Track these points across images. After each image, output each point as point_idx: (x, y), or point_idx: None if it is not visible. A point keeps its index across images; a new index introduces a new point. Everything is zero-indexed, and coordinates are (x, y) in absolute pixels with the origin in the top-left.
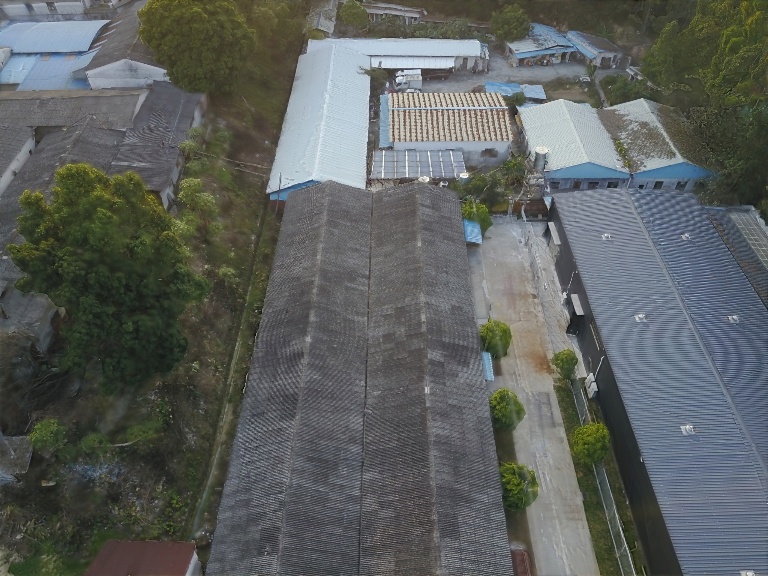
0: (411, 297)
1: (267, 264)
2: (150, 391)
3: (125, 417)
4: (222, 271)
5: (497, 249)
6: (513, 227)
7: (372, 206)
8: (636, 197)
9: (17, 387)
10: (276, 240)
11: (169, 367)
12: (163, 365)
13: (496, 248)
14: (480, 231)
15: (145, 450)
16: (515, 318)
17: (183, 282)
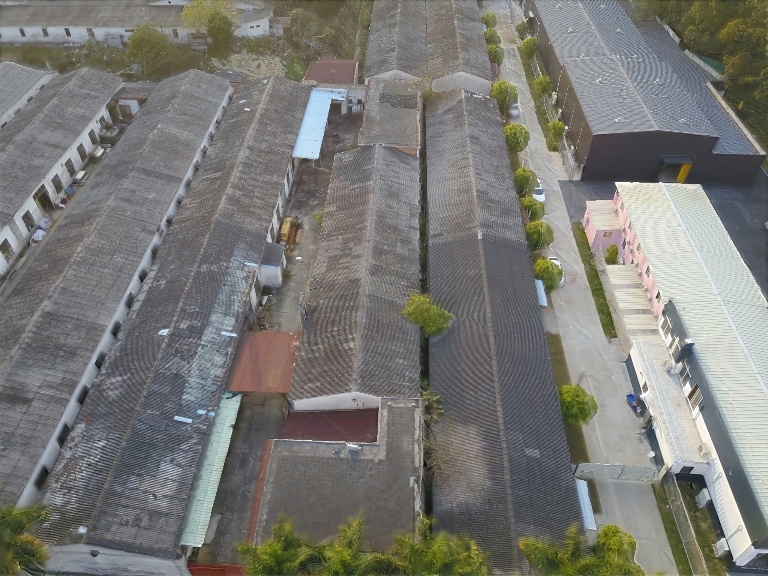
0: (448, 2)
1: (368, 7)
2: (326, 26)
3: (318, 32)
4: None
5: (493, 9)
6: (503, 2)
7: None
8: None
9: (279, 3)
10: (371, 1)
11: (337, 11)
12: (336, 8)
13: (492, 8)
14: None
15: (328, 42)
16: (500, 29)
17: None
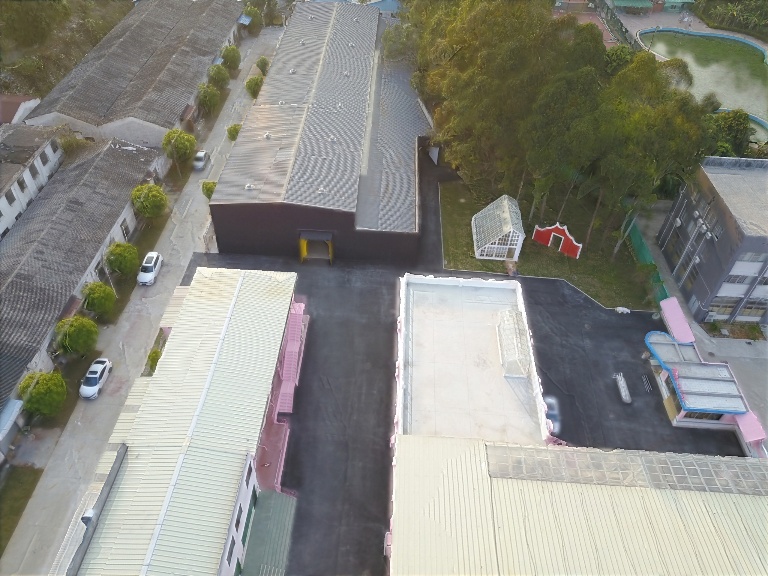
0: None
1: None
2: (33, 55)
3: None
4: (87, 19)
5: (267, 39)
6: None
7: (190, 6)
8: (342, 5)
9: None
10: None
11: (42, 39)
12: (38, 36)
13: (266, 38)
14: (250, 20)
15: (25, 74)
16: None
17: (55, 2)
